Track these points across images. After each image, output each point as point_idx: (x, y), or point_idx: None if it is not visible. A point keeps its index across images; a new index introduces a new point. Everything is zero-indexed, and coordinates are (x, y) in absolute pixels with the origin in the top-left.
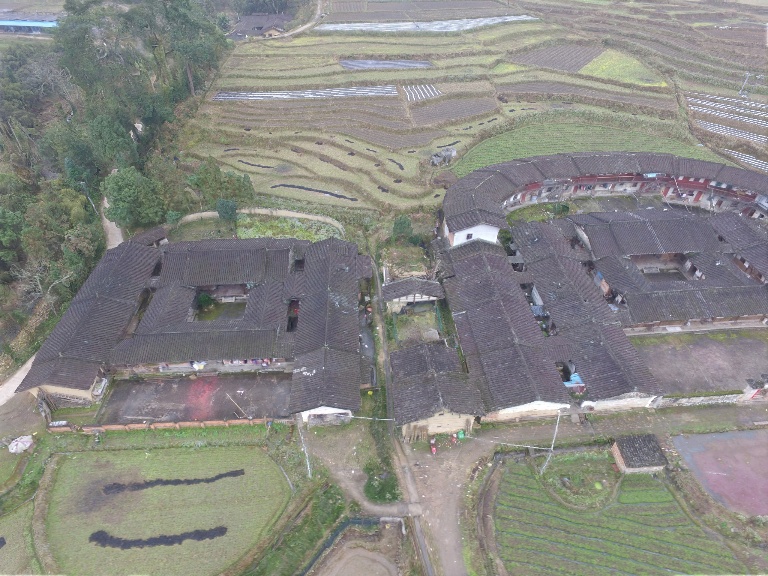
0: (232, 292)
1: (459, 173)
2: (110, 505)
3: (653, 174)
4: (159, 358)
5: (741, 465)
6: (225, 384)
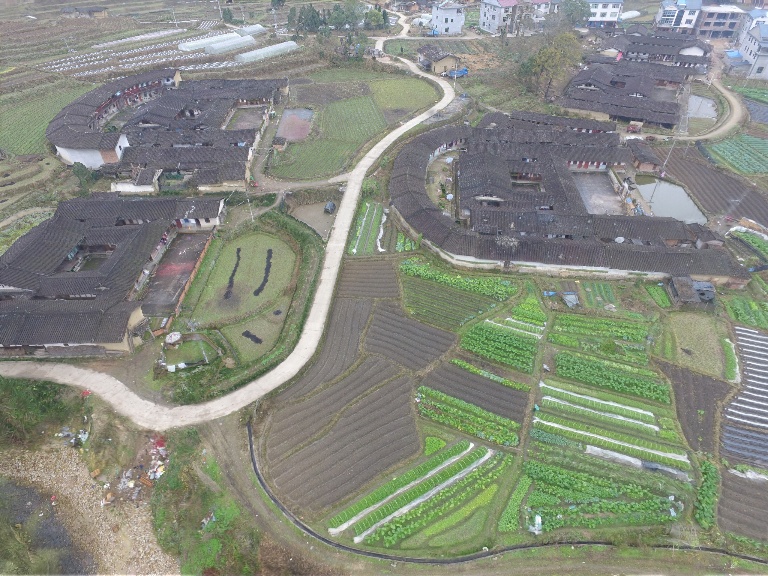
0: (68, 268)
1: (27, 152)
2: (238, 293)
3: (118, 93)
4: (134, 274)
5: (290, 132)
6: (170, 261)
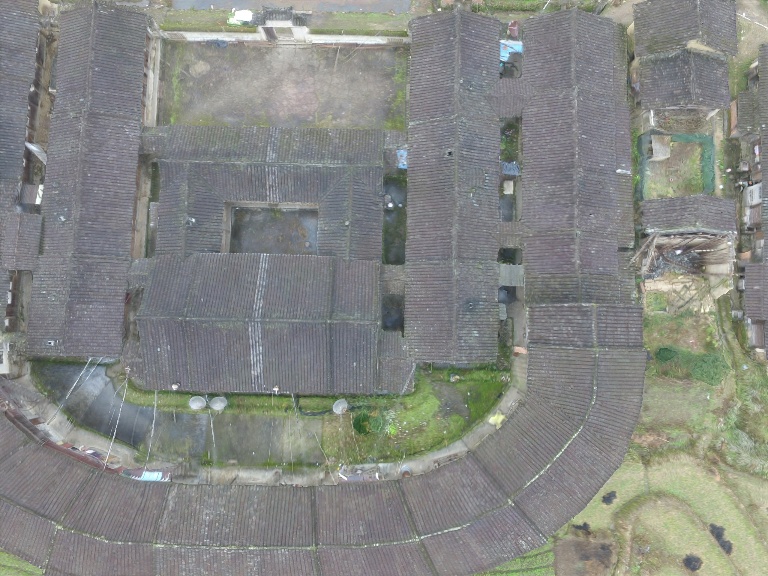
0: None
1: None
2: None
3: (148, 479)
4: None
5: None
6: None
